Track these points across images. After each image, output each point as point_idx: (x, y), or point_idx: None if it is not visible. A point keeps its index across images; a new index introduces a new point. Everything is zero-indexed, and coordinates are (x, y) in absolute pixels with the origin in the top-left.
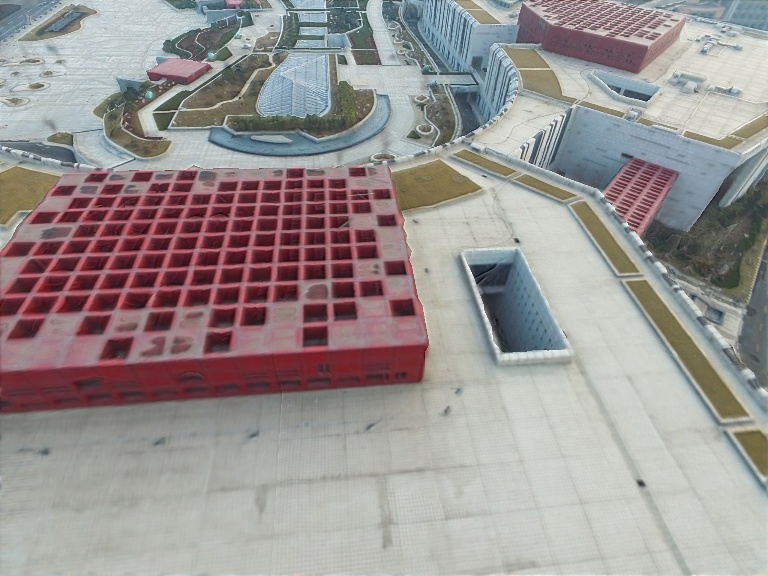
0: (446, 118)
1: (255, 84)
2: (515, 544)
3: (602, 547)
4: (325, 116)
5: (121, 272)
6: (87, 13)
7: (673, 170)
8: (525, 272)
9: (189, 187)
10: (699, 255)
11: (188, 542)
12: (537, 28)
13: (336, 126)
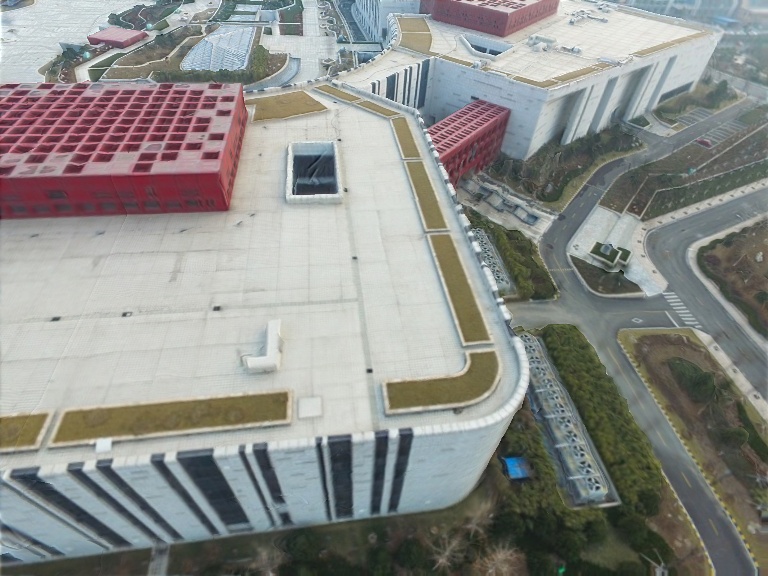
0: None
1: (183, 48)
2: (256, 282)
3: (312, 284)
4: (235, 70)
5: (16, 135)
6: None
7: (506, 108)
8: None
9: (81, 93)
10: (532, 178)
11: (42, 278)
12: (429, 1)
13: (245, 79)
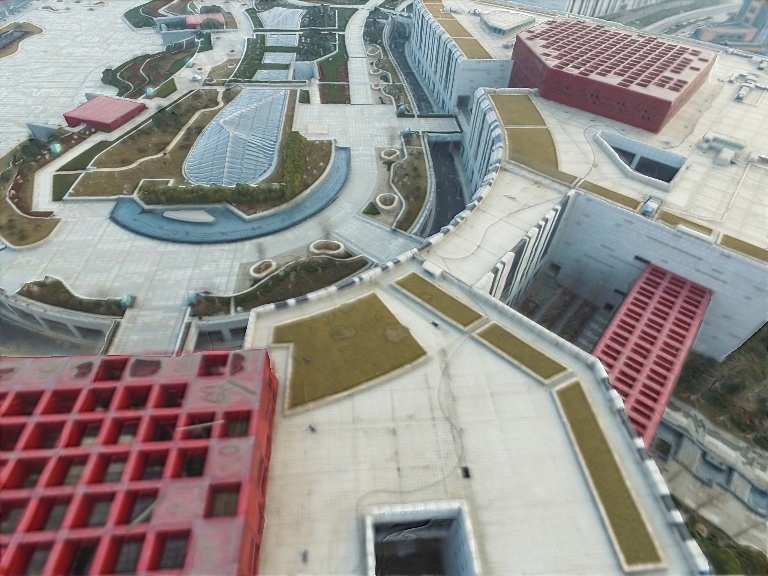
0: (416, 183)
1: (191, 132)
2: None
3: None
4: (259, 186)
5: None
6: (31, 32)
7: (705, 287)
8: (469, 560)
9: None
10: (737, 396)
11: None
12: (533, 68)
13: (273, 198)
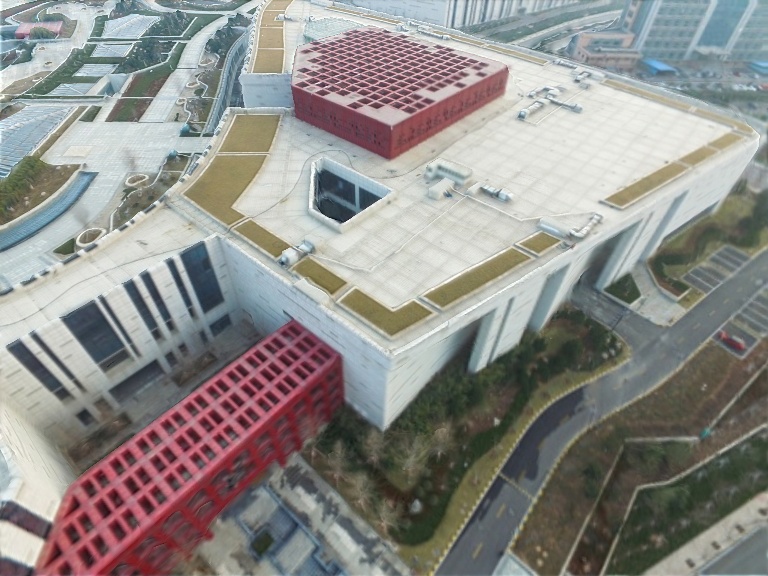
0: None
1: None
2: None
3: None
4: None
5: None
6: None
7: (334, 350)
8: None
9: None
10: (391, 473)
11: None
12: None
13: None
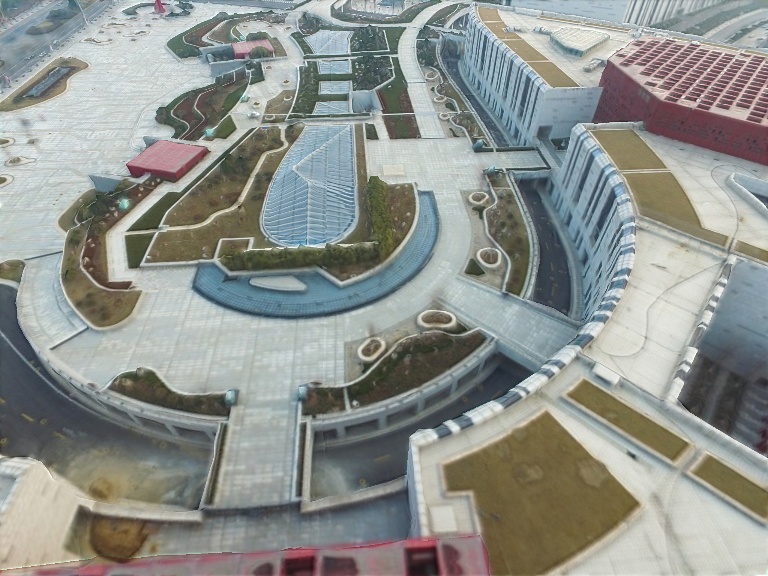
0: (516, 233)
1: (261, 179)
2: None
3: None
4: (351, 247)
5: None
6: (77, 68)
7: None
8: None
9: None
10: None
11: None
12: (635, 99)
13: (367, 259)
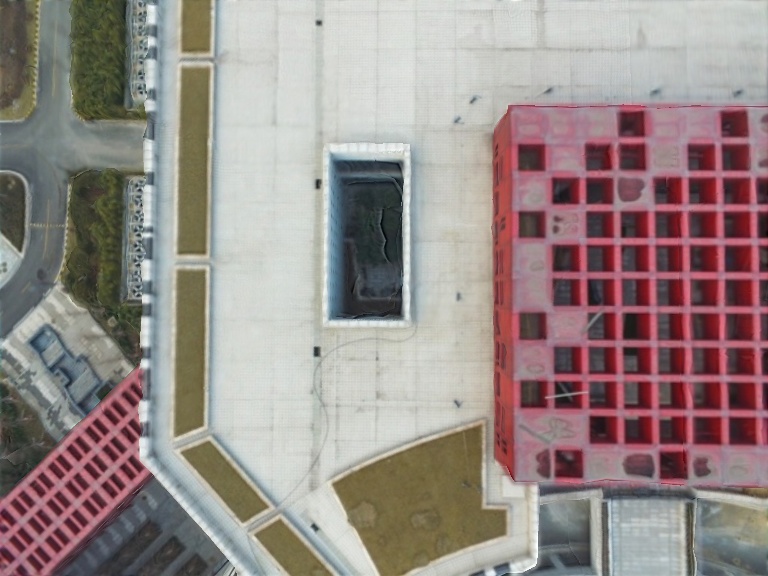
0: None
1: None
2: None
3: None
4: None
5: None
6: None
7: None
8: None
9: None
10: None
11: (693, 13)
12: None
13: None
